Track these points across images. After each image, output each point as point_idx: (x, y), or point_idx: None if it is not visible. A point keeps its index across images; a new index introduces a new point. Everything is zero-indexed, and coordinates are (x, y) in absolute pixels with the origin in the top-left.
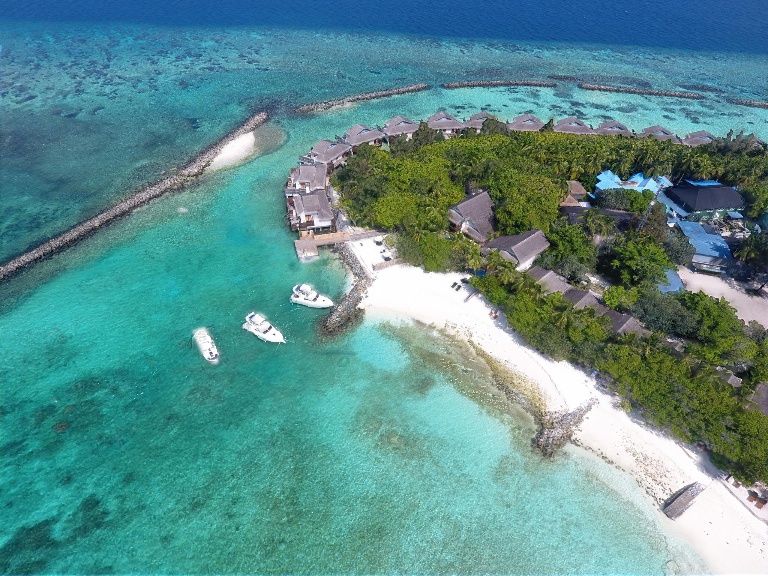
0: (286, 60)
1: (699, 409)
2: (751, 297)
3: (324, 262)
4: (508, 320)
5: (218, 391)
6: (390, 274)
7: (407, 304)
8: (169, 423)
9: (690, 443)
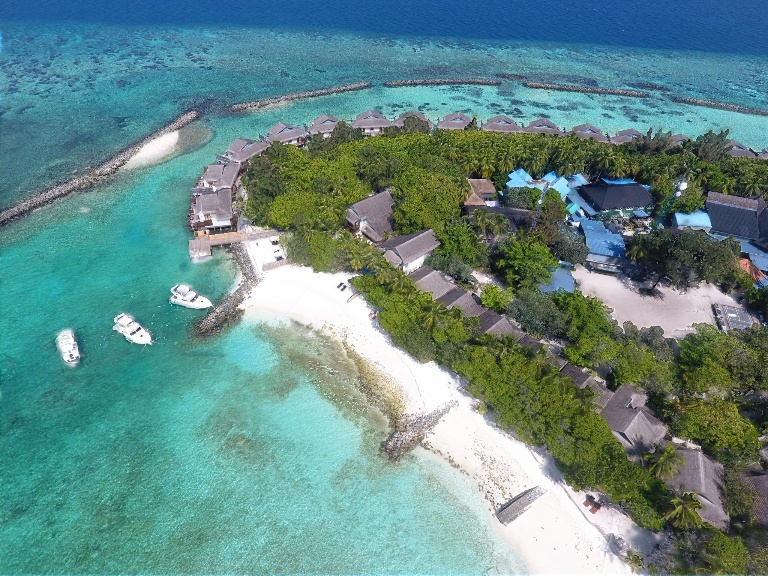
0: (232, 58)
1: (541, 412)
2: (643, 297)
3: (217, 262)
4: (378, 321)
5: (72, 394)
6: (279, 274)
7: (289, 305)
8: (12, 427)
9: (538, 446)
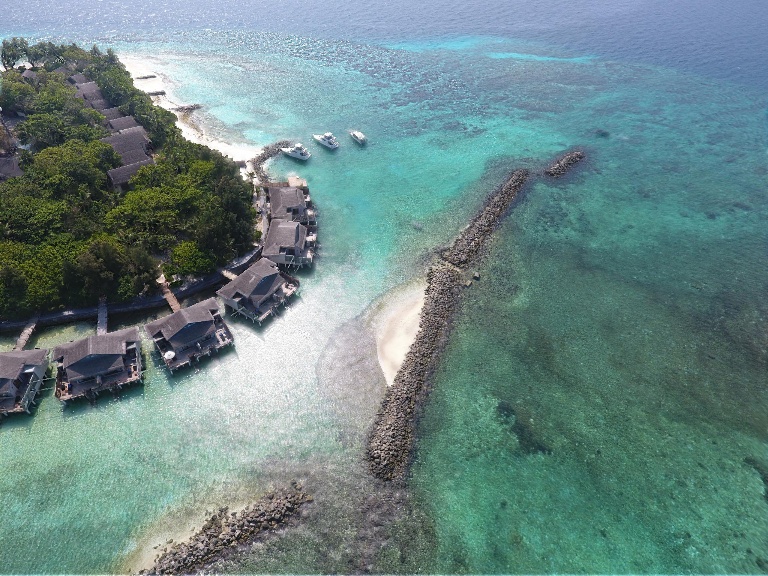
0: None
1: None
2: None
3: (284, 180)
4: None
5: None
6: None
7: None
8: None
9: None
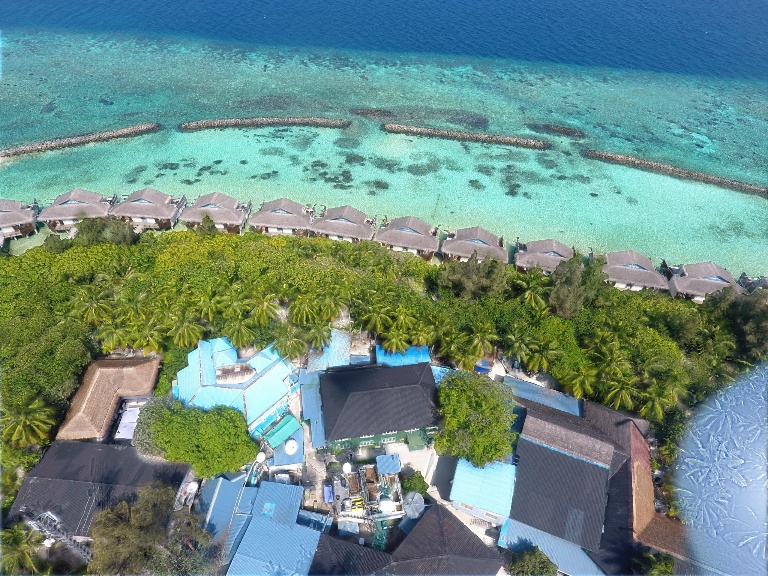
0: None
1: None
2: None
3: None
4: None
5: None
6: None
7: None
8: None
9: None
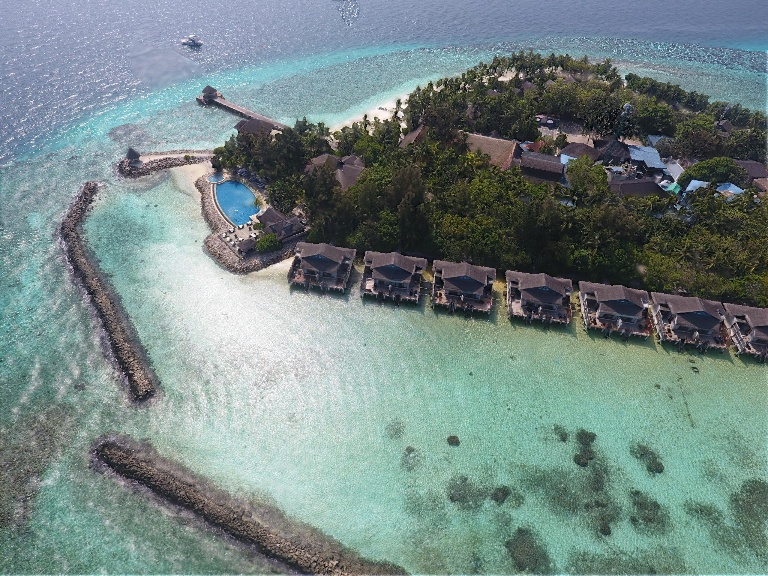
0: None
1: None
2: None
3: None
4: None
5: None
6: None
7: None
8: None
9: None
